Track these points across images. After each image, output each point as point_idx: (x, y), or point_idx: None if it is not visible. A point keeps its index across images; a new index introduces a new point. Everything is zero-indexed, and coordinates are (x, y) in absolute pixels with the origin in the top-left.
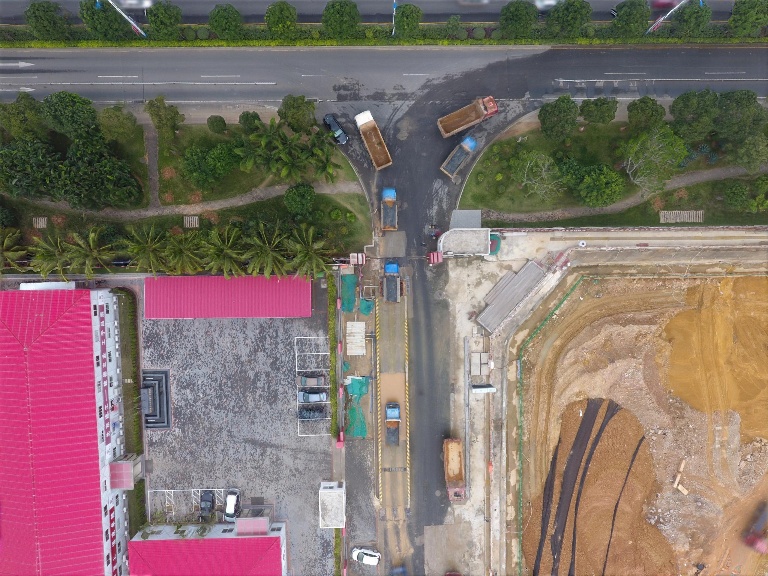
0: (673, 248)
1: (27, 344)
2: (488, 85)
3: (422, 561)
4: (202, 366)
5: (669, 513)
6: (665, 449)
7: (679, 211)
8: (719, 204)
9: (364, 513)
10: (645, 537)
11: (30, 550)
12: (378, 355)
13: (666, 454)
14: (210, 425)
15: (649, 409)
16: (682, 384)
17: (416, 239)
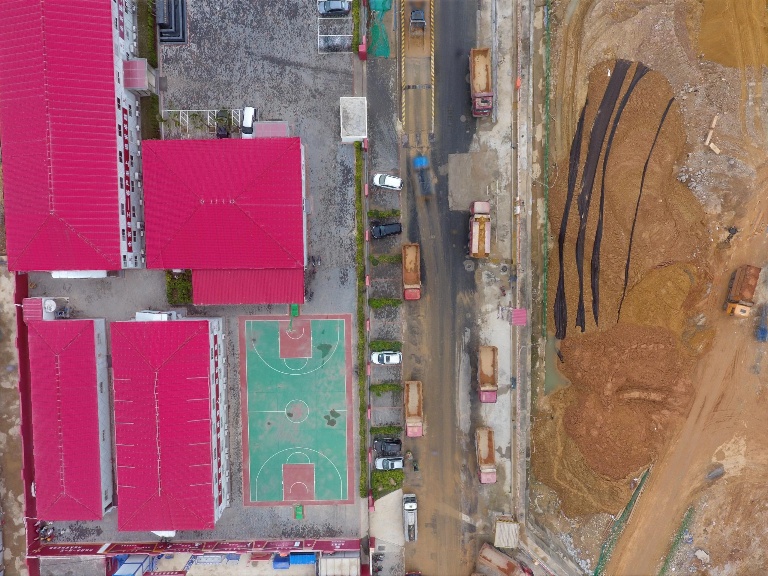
0: None
1: None
2: None
3: (446, 192)
4: None
5: (700, 173)
6: (696, 105)
7: None
8: None
9: (386, 139)
10: (676, 195)
11: (40, 123)
12: None
13: (697, 111)
14: (227, 40)
15: (680, 63)
16: (714, 44)
17: None
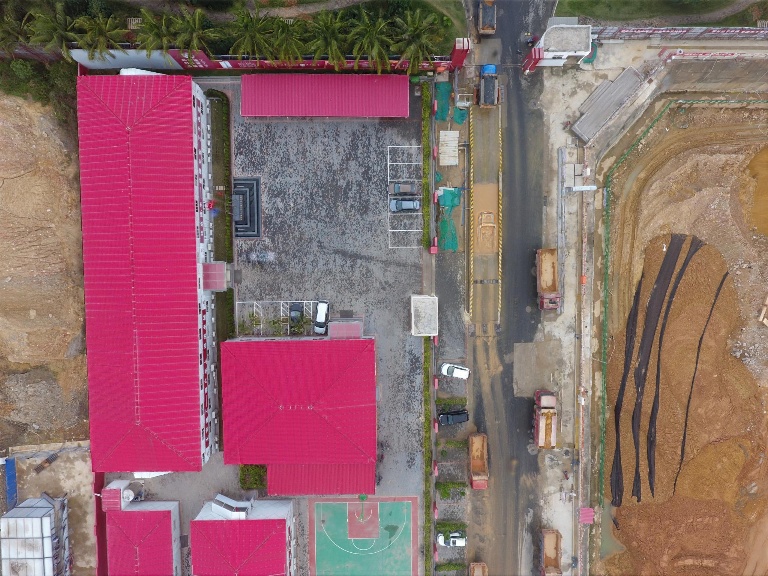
0: None
1: (129, 124)
2: None
3: (511, 379)
4: (293, 174)
5: (754, 347)
6: (750, 282)
7: None
8: None
9: (453, 329)
10: (730, 370)
11: (127, 337)
12: (472, 163)
13: (751, 288)
14: (300, 235)
15: (735, 241)
16: (767, 219)
17: (511, 47)
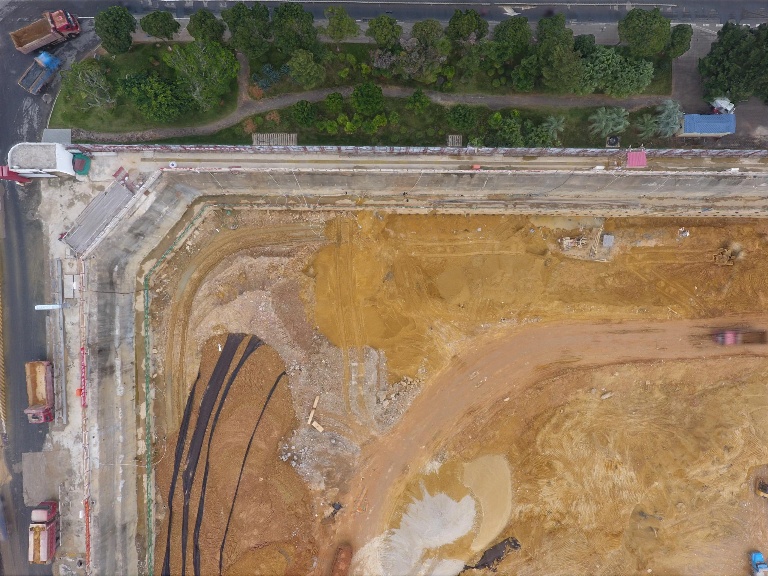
0: (265, 171)
1: None
2: (76, 3)
3: (21, 489)
4: None
5: (304, 450)
6: (300, 385)
7: (272, 134)
8: (312, 127)
9: None
10: (276, 474)
11: None
12: None
13: (301, 390)
14: None
15: (284, 343)
16: (324, 320)
17: (7, 158)
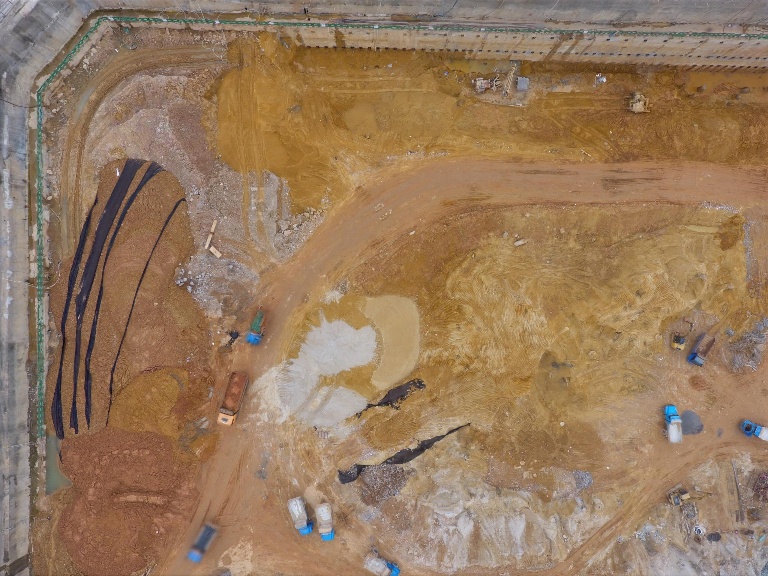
0: None
1: None
2: None
3: None
4: None
5: (201, 276)
6: (198, 209)
7: None
8: None
9: None
10: (171, 298)
11: None
12: None
13: (199, 214)
14: None
15: (182, 166)
16: (225, 146)
17: None
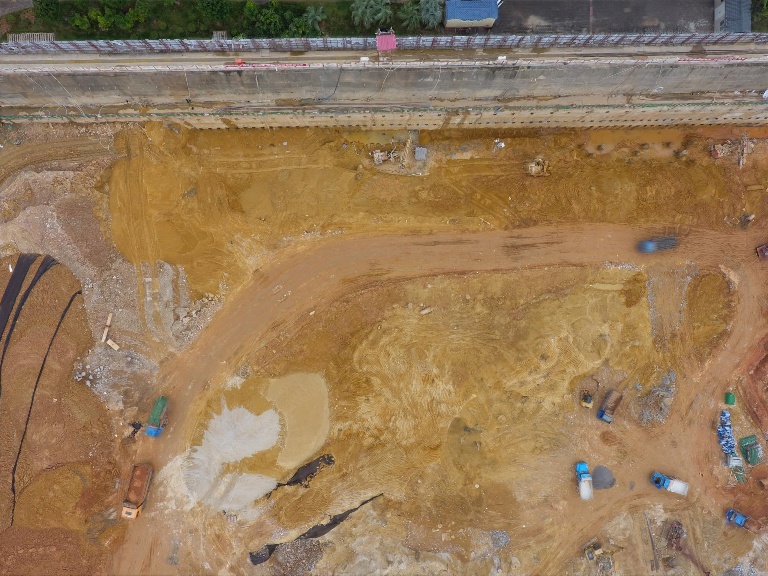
0: None
1: None
2: None
3: None
4: None
5: (100, 370)
6: (92, 302)
7: (28, 33)
8: (69, 26)
9: None
10: (70, 394)
11: None
12: None
13: (95, 308)
14: None
15: (74, 261)
16: (118, 237)
17: None
